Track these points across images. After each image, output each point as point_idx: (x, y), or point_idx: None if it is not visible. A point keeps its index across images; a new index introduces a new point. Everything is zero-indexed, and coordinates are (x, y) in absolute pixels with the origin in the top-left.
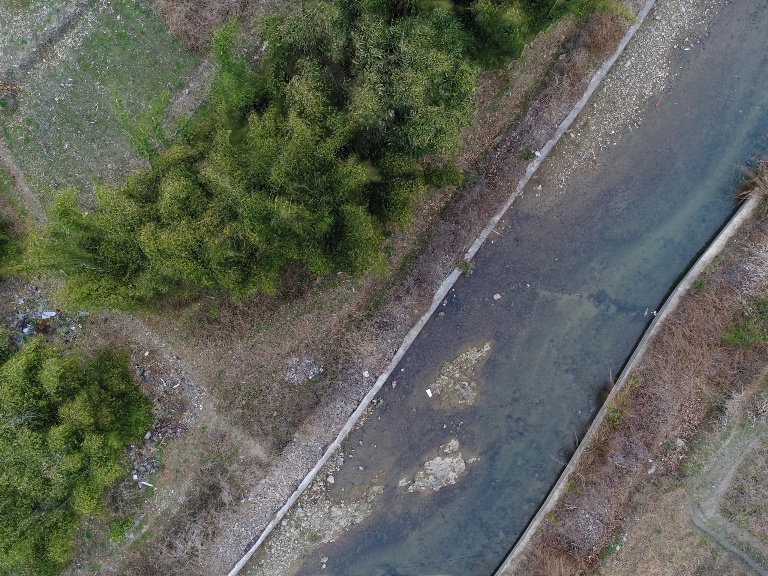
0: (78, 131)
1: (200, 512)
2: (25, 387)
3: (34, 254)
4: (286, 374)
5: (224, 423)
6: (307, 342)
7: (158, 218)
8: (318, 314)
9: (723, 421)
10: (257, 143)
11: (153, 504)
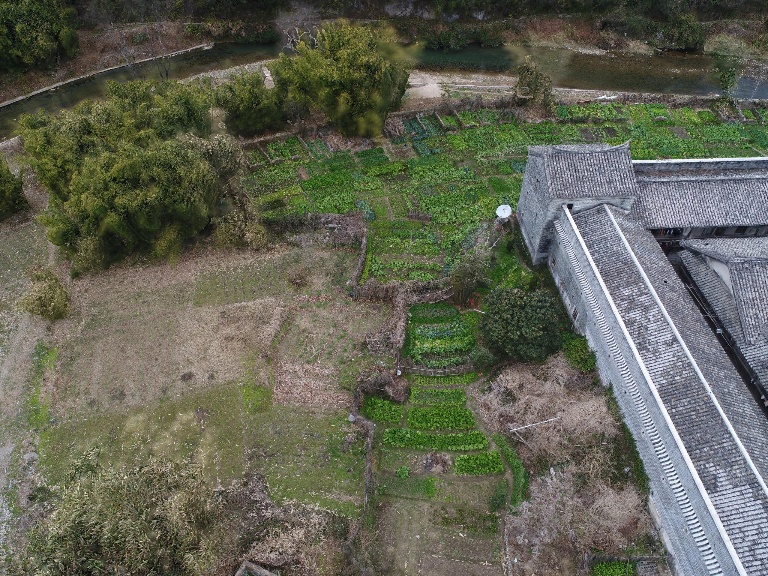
0: (6, 258)
1: None
2: None
3: (4, 164)
4: None
5: None
6: None
7: None
8: None
9: None
10: None
11: None
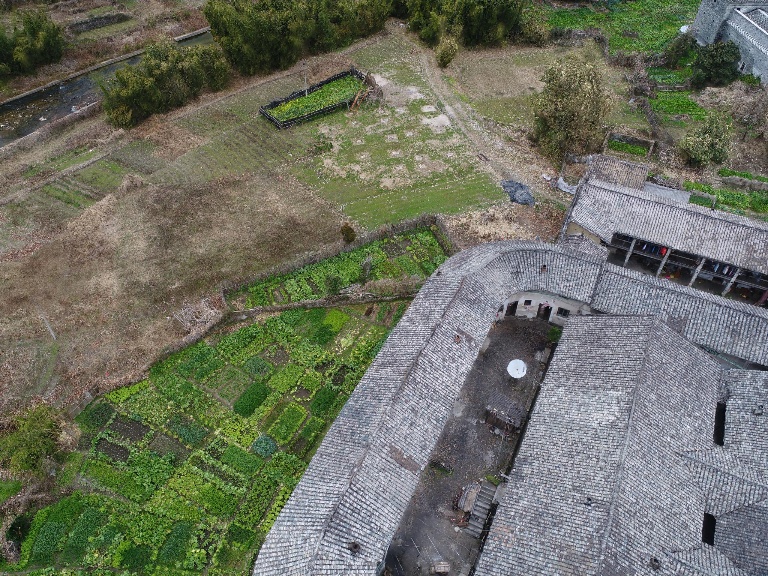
0: None
1: None
2: None
3: None
4: None
5: None
6: None
7: (353, 7)
8: None
9: (200, 6)
10: (319, 7)
11: None
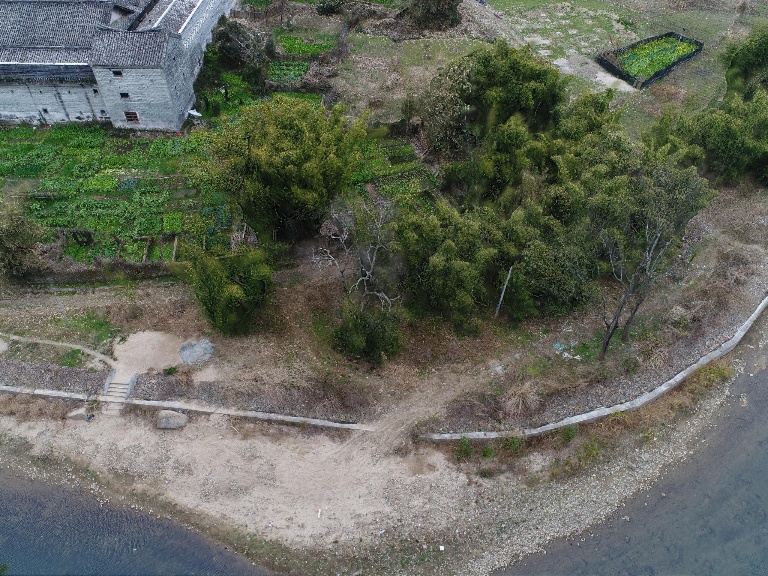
0: None
1: (733, 266)
2: (665, 158)
3: None
4: (759, 221)
5: (728, 239)
6: (764, 212)
7: None
8: (765, 204)
9: None
10: None
11: (693, 271)
